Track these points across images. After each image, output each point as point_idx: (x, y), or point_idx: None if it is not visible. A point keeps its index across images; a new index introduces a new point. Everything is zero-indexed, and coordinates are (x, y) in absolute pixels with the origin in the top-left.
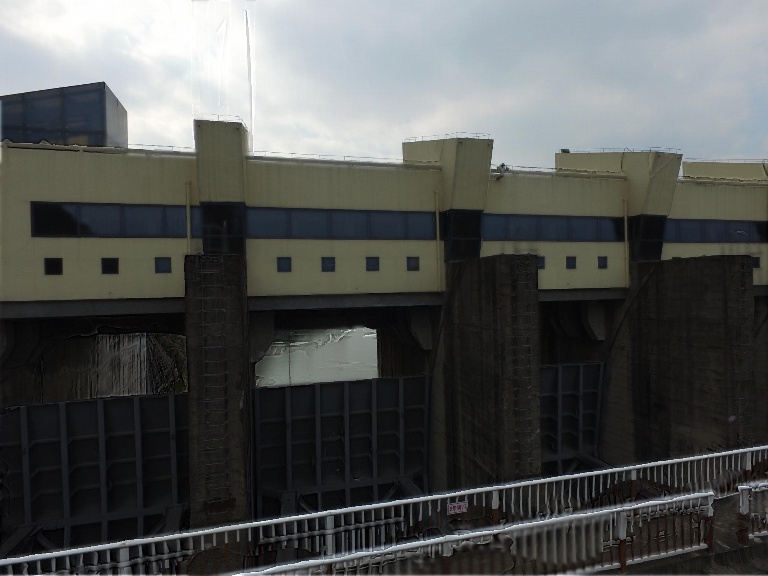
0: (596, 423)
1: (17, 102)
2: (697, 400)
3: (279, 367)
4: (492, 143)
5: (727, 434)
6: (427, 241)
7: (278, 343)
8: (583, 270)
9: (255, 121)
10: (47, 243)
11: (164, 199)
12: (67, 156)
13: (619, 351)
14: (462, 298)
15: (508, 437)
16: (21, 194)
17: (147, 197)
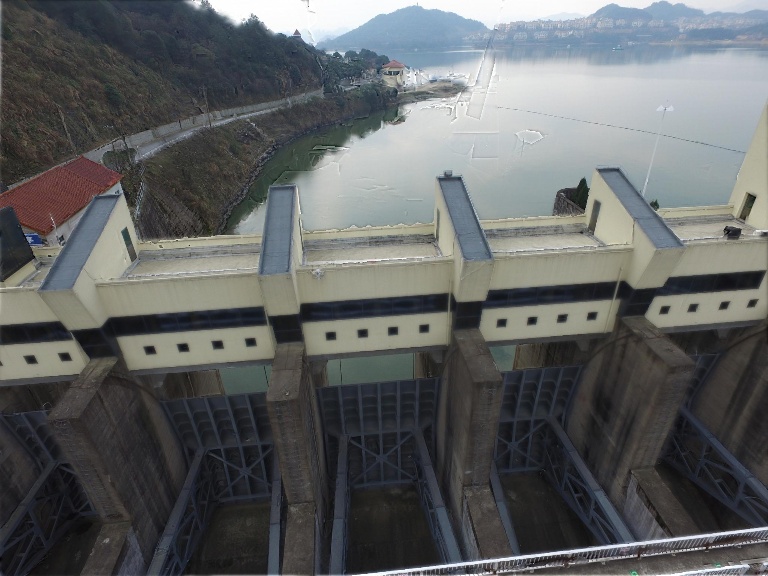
0: (433, 410)
1: None
2: (459, 448)
3: (306, 193)
4: (291, 277)
5: (464, 479)
6: (261, 326)
7: (316, 149)
8: (405, 335)
9: None
10: None
11: (49, 318)
12: None
13: (444, 378)
14: None
15: (287, 487)
16: None
17: (36, 318)
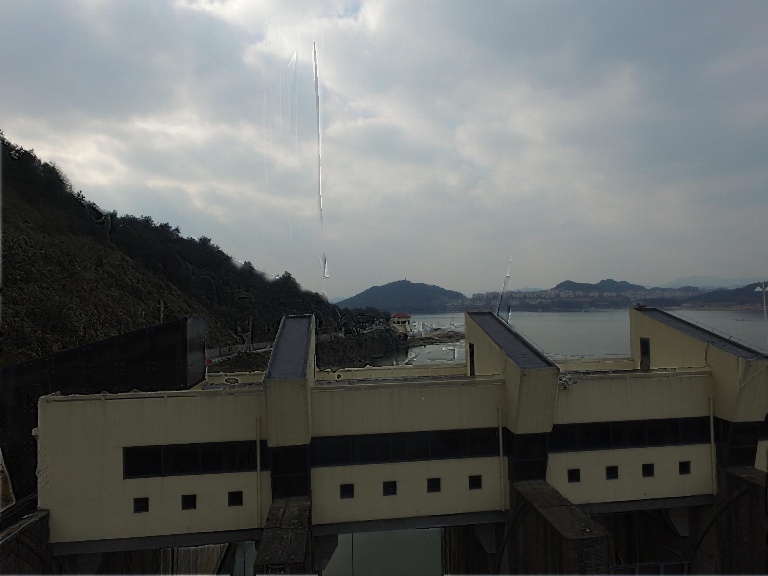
0: None
1: (113, 342)
2: None
3: None
4: (558, 371)
5: None
6: (490, 458)
7: None
8: (662, 478)
9: (322, 147)
10: (136, 484)
11: (237, 435)
12: (153, 403)
13: (706, 557)
14: (527, 537)
15: None
16: (115, 440)
17: (222, 435)
